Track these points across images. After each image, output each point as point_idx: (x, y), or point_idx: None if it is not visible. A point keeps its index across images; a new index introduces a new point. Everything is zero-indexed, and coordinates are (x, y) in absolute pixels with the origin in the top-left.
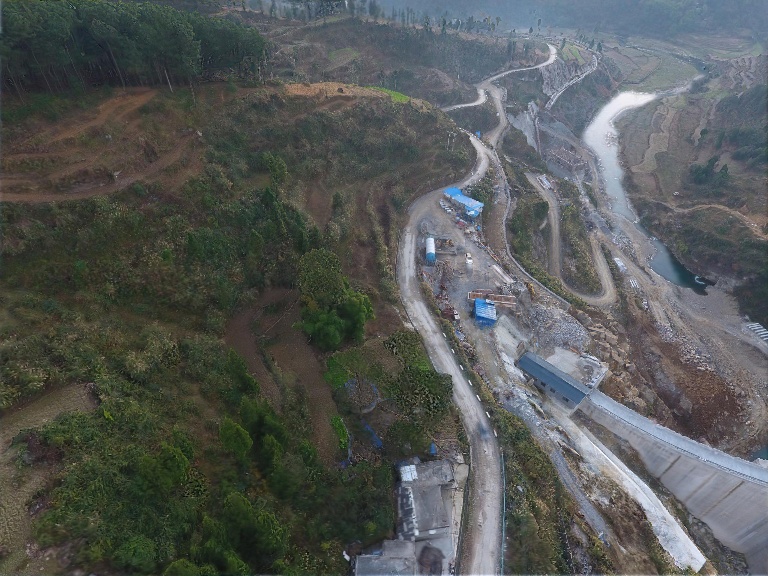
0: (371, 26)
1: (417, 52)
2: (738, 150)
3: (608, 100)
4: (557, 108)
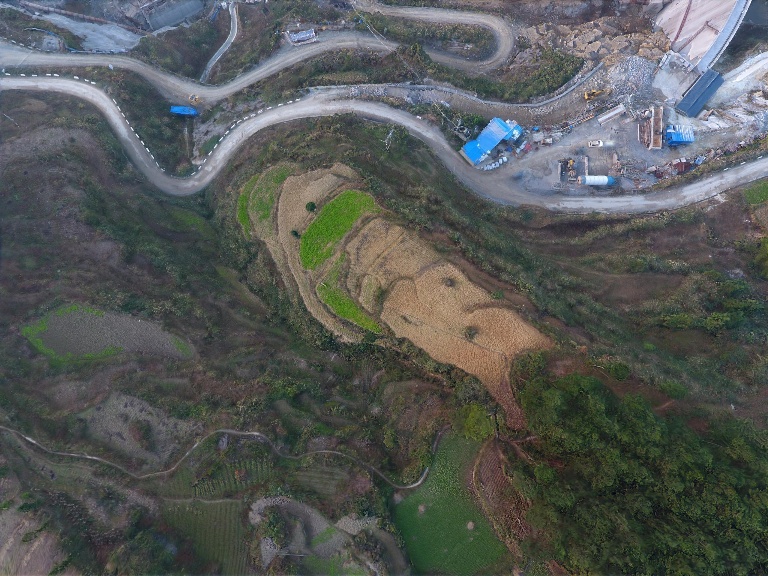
0: None
1: None
2: None
3: None
4: None
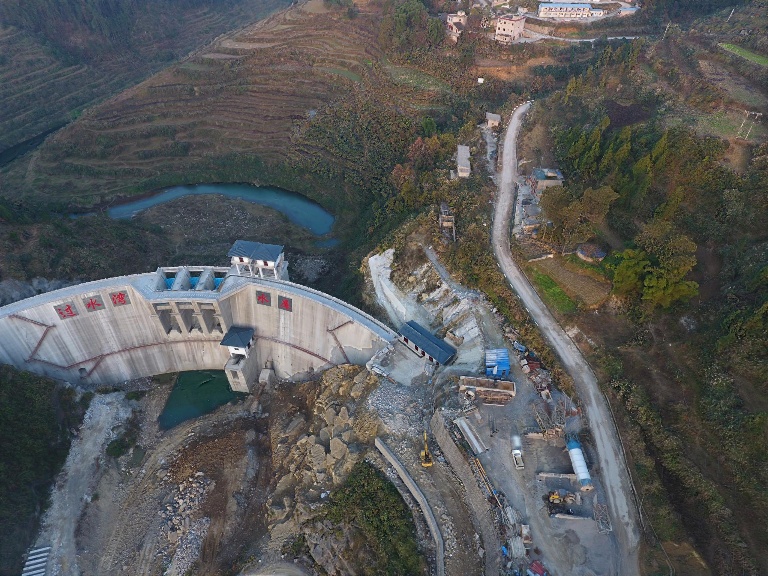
0: None
1: None
2: None
3: None
4: None
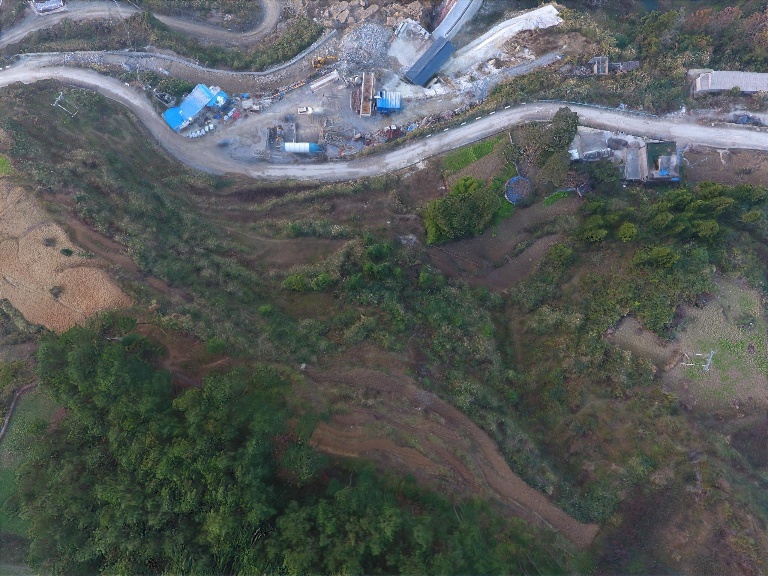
0: None
1: None
2: None
3: None
4: None
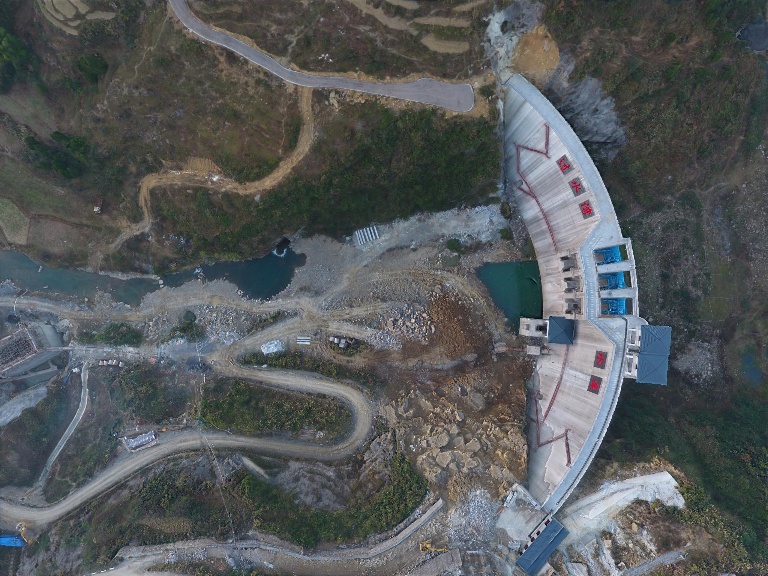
0: None
1: None
2: None
3: None
4: None
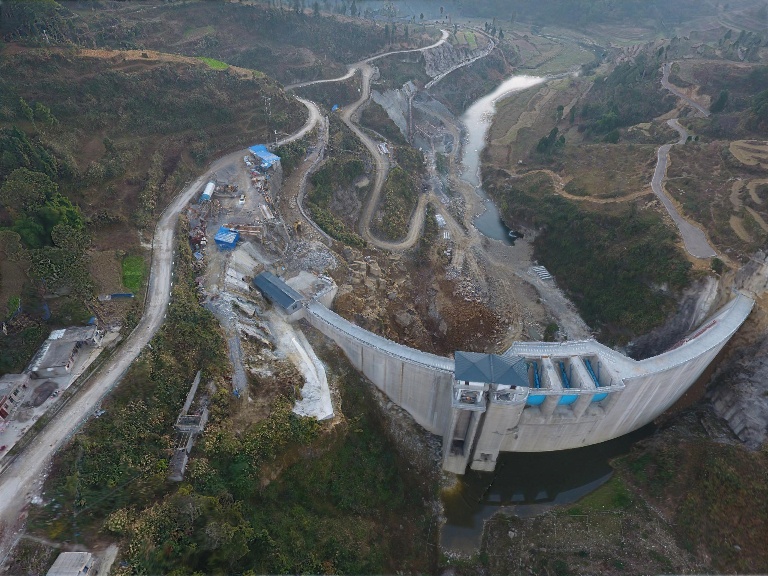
0: (235, 7)
1: (285, 32)
2: (582, 123)
3: (498, 83)
4: (438, 88)
